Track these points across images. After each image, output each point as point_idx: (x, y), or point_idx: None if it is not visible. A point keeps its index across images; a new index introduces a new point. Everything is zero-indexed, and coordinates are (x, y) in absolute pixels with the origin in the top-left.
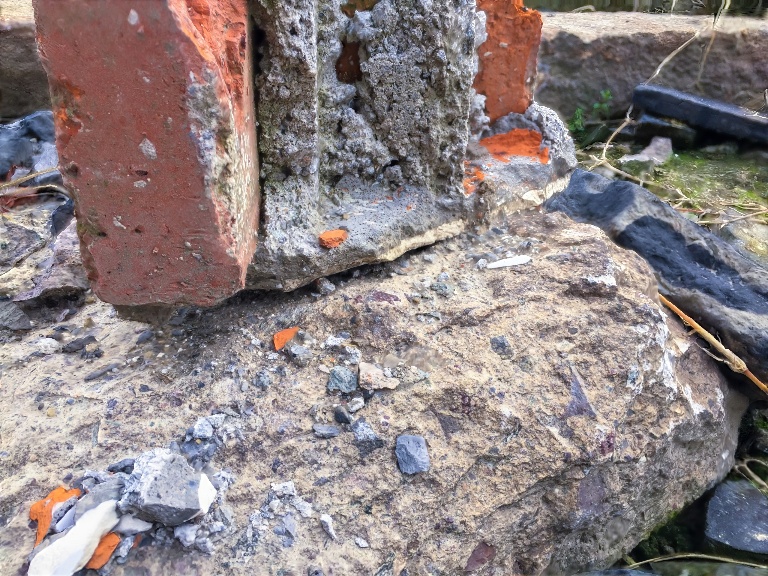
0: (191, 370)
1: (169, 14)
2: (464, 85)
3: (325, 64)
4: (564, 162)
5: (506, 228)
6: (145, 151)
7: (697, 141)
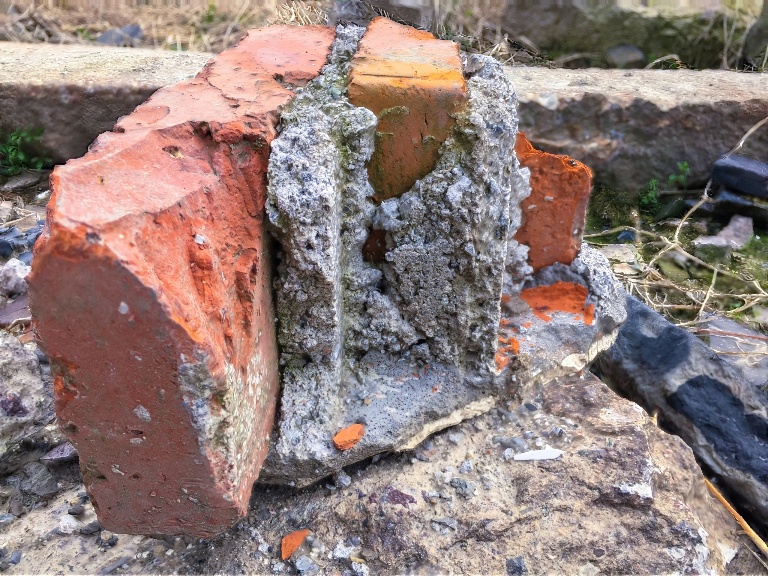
0: None
1: (158, 307)
2: (496, 270)
3: (350, 251)
4: (611, 320)
5: (541, 401)
6: (140, 415)
7: None
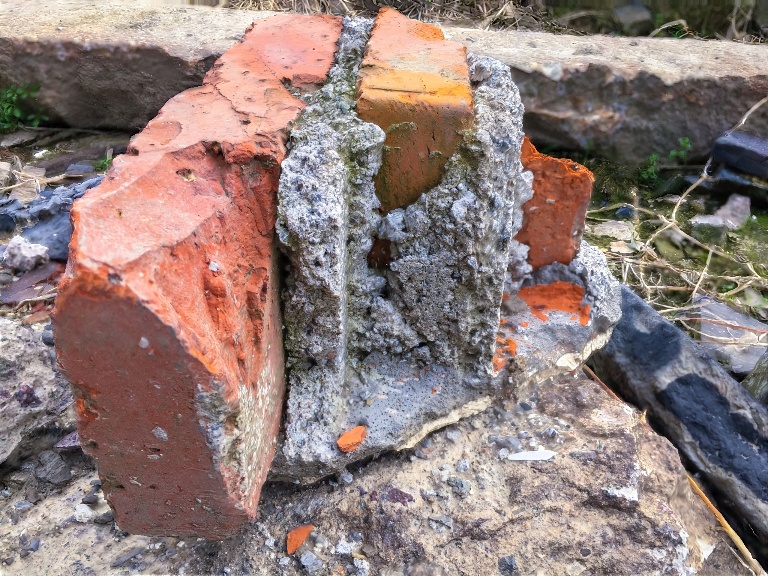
0: (205, 573)
1: (177, 343)
2: (497, 280)
3: (356, 259)
4: (606, 320)
5: (535, 401)
6: (157, 435)
7: None
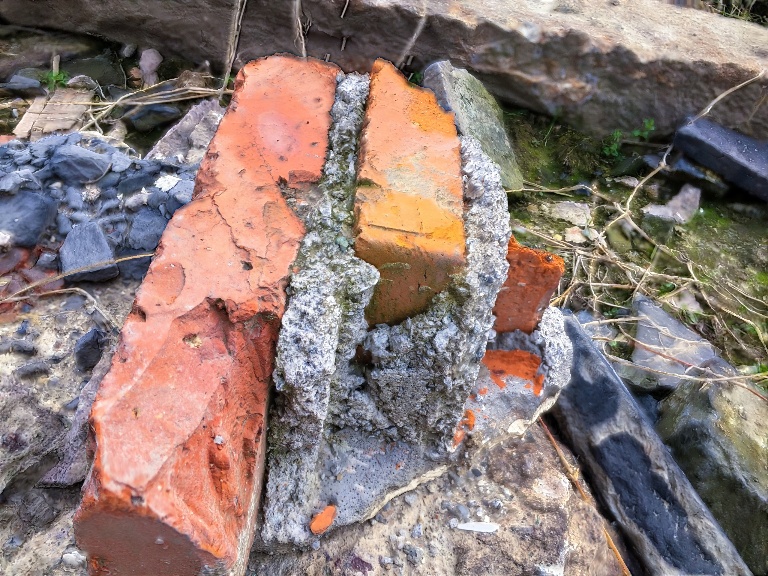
0: None
1: None
2: (467, 386)
3: None
4: (556, 387)
5: (485, 466)
6: None
7: (727, 195)
